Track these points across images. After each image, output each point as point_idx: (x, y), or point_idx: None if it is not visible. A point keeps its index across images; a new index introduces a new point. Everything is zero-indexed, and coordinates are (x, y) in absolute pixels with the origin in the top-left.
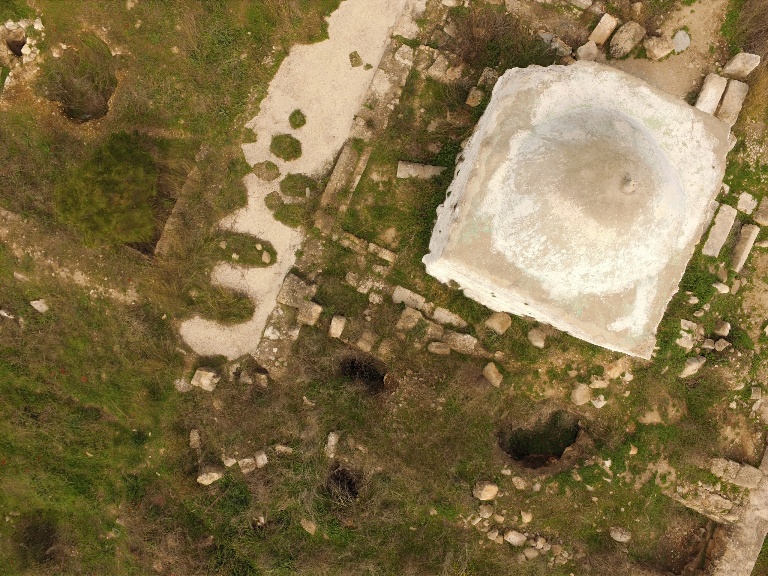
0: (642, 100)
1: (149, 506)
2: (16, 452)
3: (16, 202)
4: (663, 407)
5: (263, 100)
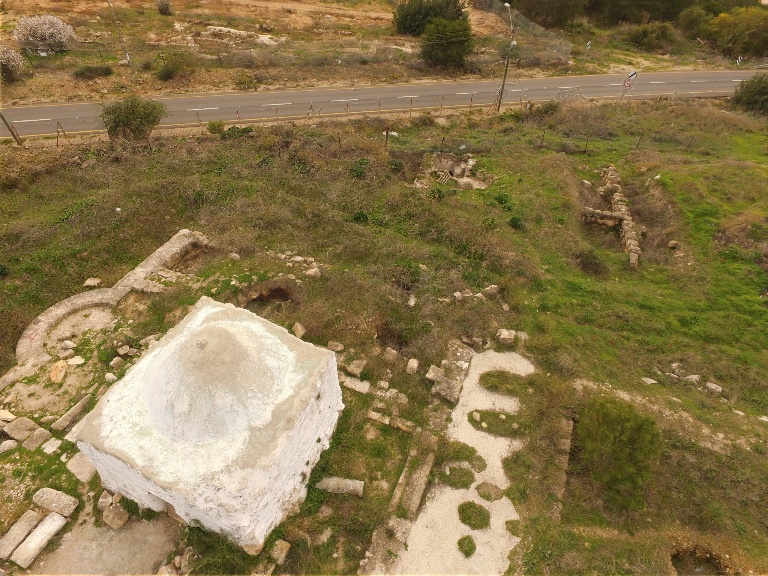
0: (146, 453)
1: (525, 276)
2: (623, 301)
3: (711, 458)
4: (184, 314)
5: (507, 569)
